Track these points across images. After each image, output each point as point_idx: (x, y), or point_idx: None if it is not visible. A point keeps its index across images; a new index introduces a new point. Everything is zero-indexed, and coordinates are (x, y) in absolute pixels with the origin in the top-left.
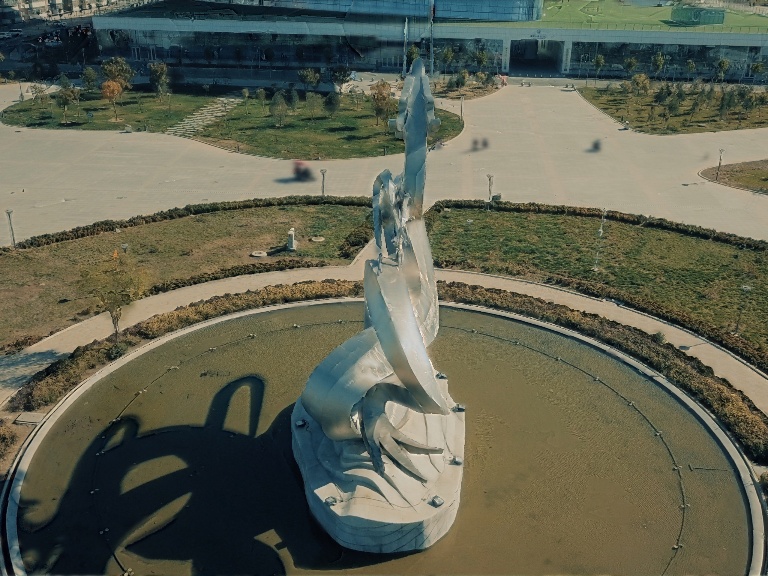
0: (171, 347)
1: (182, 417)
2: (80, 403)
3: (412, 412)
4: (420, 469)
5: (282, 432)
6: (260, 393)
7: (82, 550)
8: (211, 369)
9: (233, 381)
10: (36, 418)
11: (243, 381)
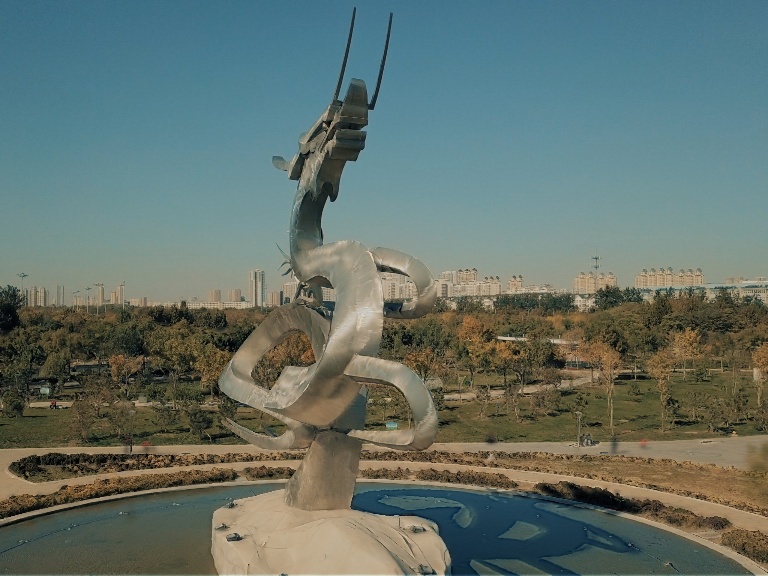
0: None
1: None
2: (702, 550)
3: None
4: None
5: (453, 567)
6: None
7: (488, 504)
8: None
9: None
10: None
11: None
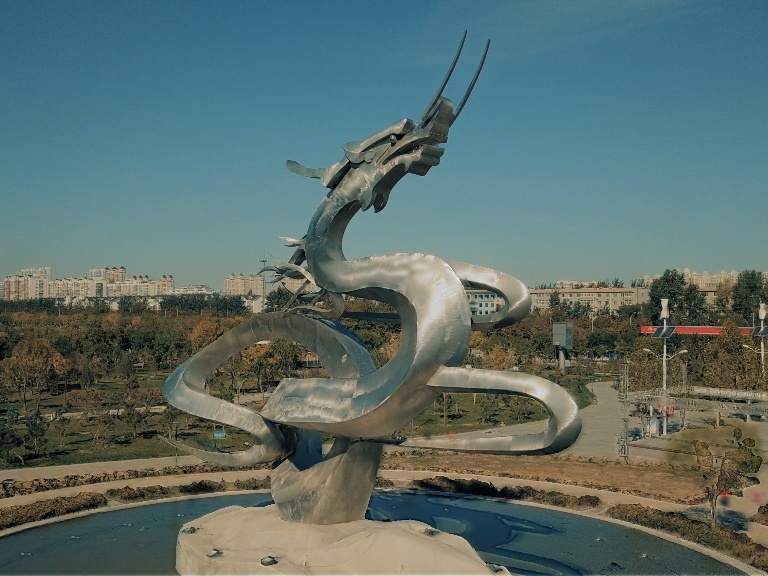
0: (715, 567)
1: (527, 544)
2: (604, 524)
3: (292, 523)
4: (231, 531)
5: None
6: (534, 575)
7: None
8: (627, 570)
9: (581, 571)
10: (588, 511)
11: (573, 573)
